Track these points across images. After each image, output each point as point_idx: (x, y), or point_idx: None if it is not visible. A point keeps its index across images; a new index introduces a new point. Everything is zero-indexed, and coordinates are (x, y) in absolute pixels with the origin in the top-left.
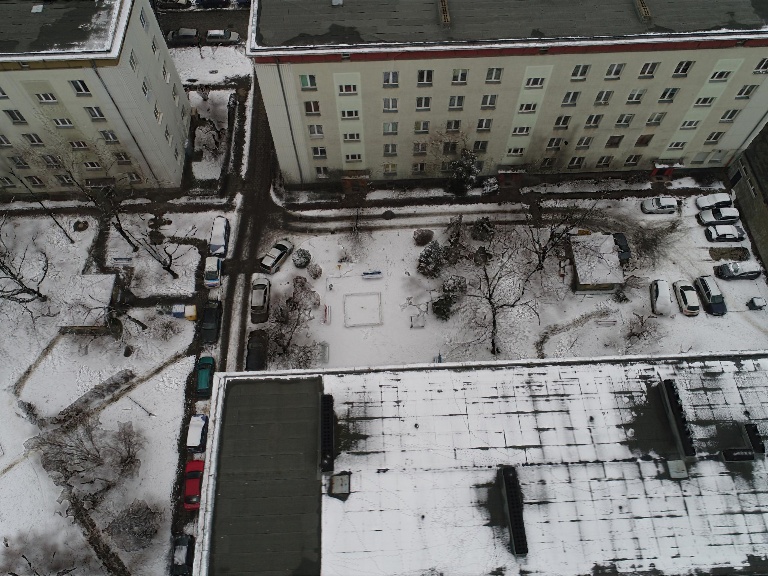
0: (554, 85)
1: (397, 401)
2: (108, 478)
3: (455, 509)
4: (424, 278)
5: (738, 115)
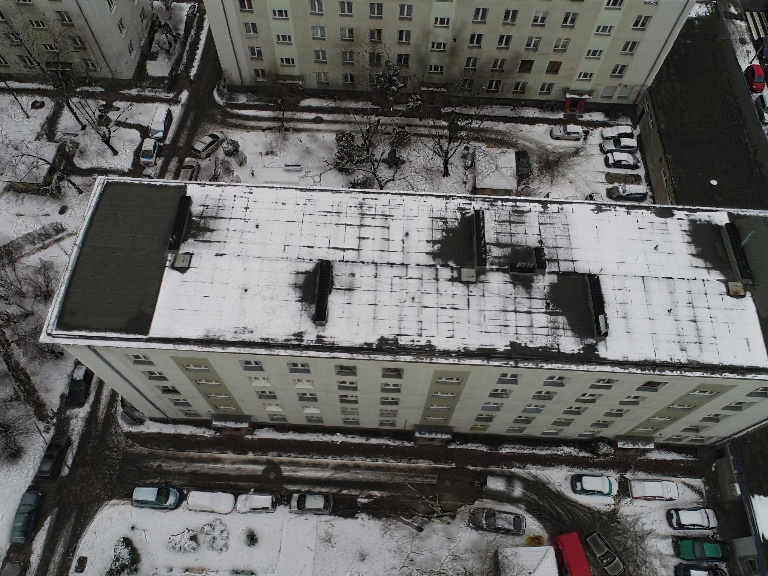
0: None
1: (246, 208)
2: (27, 308)
3: (274, 287)
4: (339, 174)
5: (637, 48)
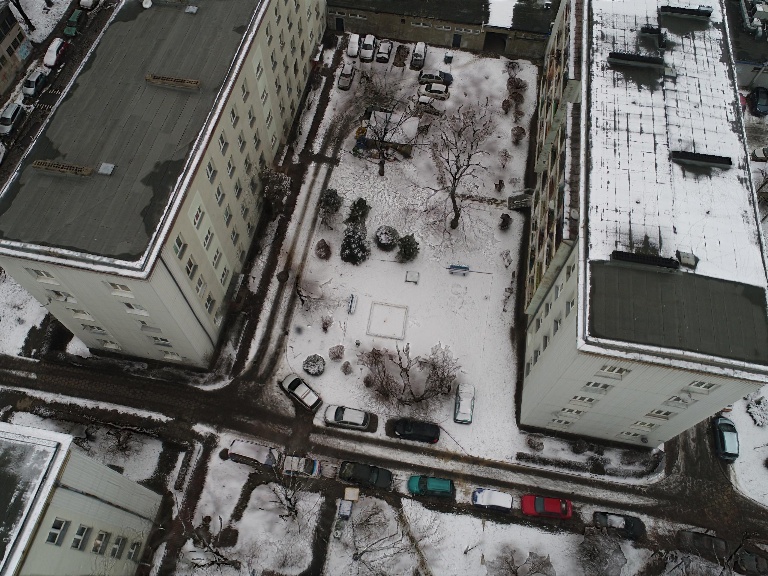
0: (265, 60)
1: (616, 211)
2: None
3: (701, 193)
4: (367, 262)
5: None
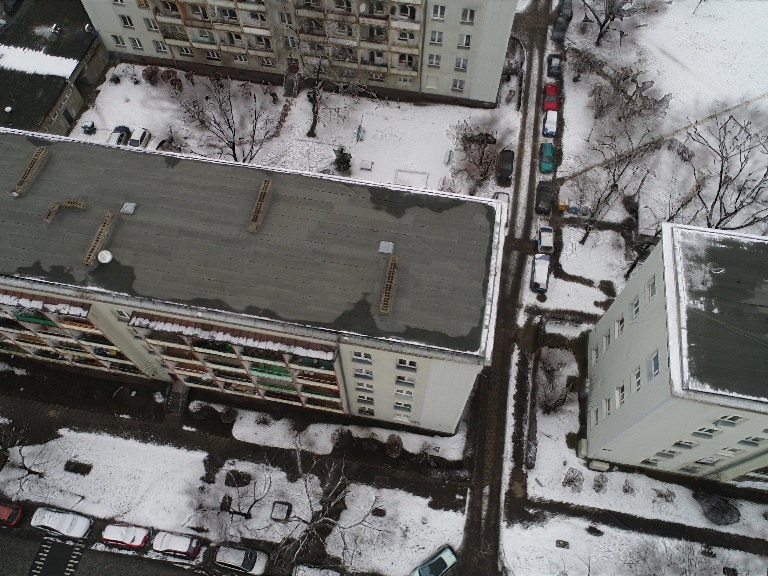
0: None
1: None
2: None
3: None
4: None
5: None
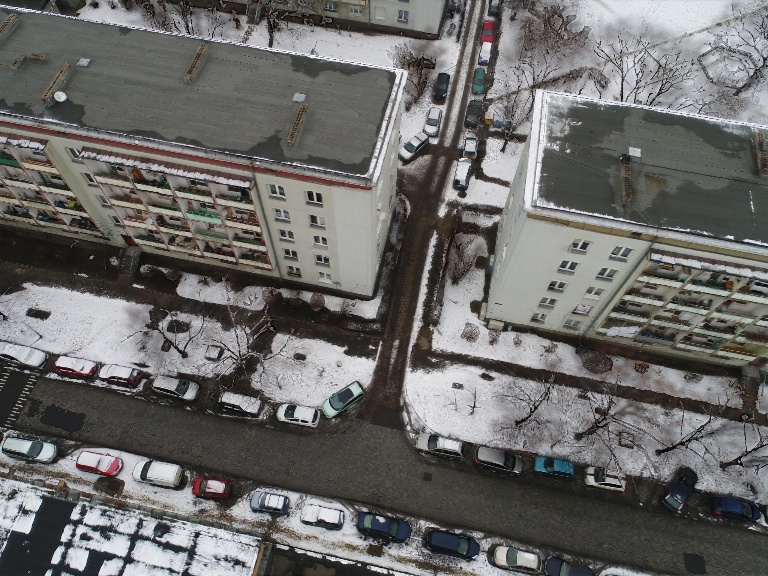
0: None
1: None
2: None
3: None
4: None
5: None
